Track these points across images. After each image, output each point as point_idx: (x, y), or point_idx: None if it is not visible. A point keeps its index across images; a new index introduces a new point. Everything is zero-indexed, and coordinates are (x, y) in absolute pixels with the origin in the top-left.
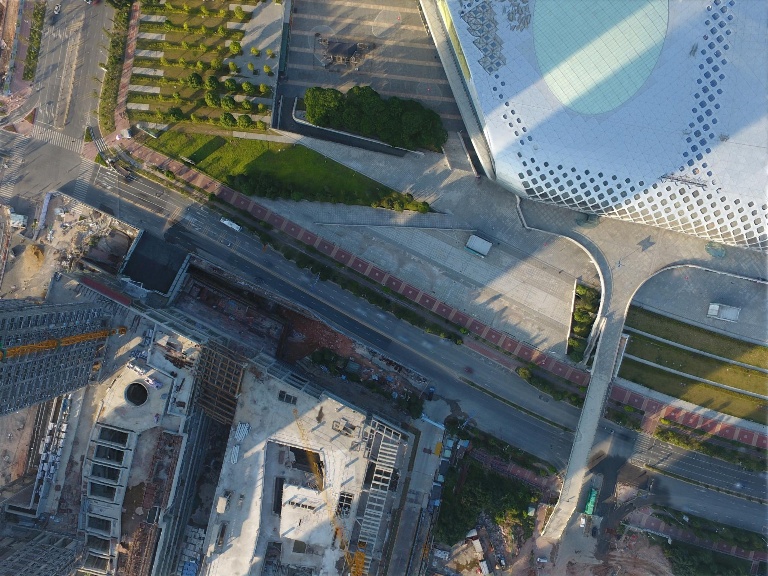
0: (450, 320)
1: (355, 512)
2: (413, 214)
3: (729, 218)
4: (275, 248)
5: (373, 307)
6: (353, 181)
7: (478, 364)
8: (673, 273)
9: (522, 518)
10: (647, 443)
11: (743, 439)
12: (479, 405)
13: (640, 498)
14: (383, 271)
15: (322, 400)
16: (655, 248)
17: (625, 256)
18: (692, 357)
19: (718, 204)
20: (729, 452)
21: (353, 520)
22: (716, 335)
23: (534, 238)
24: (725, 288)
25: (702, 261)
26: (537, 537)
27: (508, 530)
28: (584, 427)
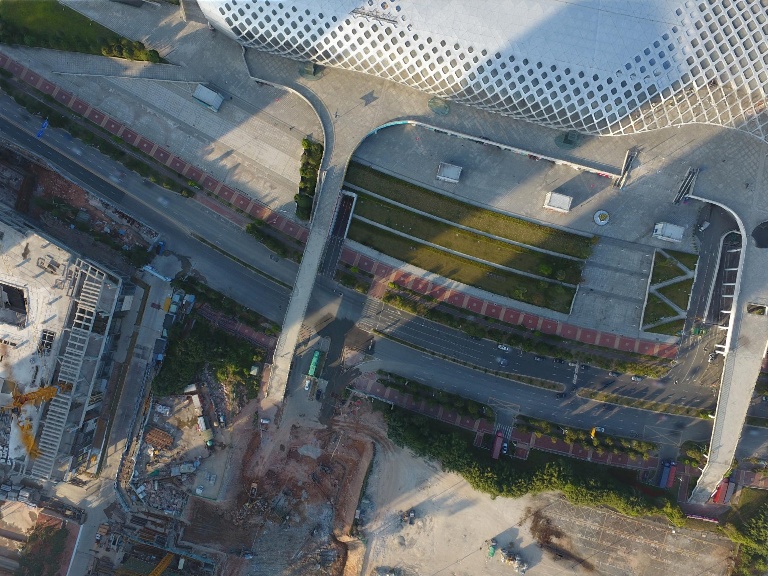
0: (184, 175)
1: (56, 350)
2: (148, 66)
3: (426, 60)
4: (8, 93)
5: (108, 159)
6: (90, 30)
7: (210, 221)
8: (404, 133)
9: (245, 377)
10: (376, 308)
11: (472, 307)
12: (210, 262)
13: (366, 363)
14: (119, 123)
15: (28, 236)
16: (378, 103)
17: (348, 110)
18: (421, 220)
19: (412, 43)
20: (458, 320)
21: (53, 358)
22: (444, 198)
23: (266, 93)
24: (455, 151)
25: (425, 118)
26: (262, 398)
27: (230, 388)
28: (301, 282)
